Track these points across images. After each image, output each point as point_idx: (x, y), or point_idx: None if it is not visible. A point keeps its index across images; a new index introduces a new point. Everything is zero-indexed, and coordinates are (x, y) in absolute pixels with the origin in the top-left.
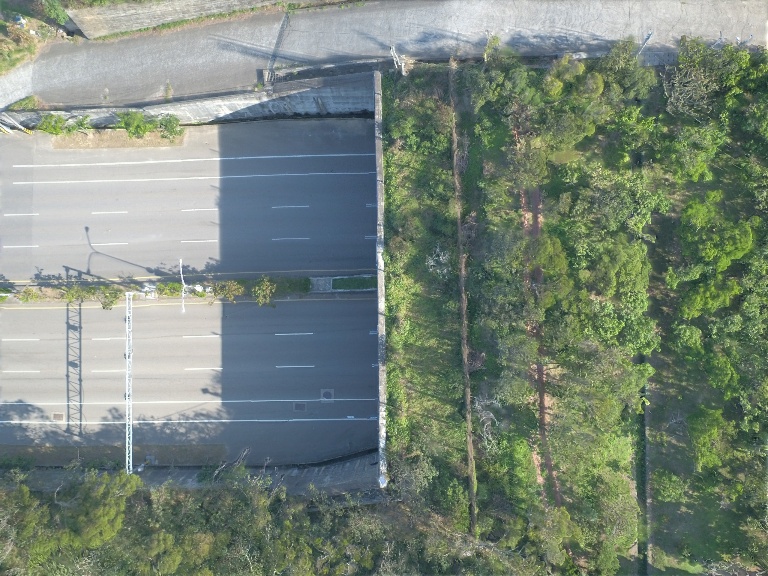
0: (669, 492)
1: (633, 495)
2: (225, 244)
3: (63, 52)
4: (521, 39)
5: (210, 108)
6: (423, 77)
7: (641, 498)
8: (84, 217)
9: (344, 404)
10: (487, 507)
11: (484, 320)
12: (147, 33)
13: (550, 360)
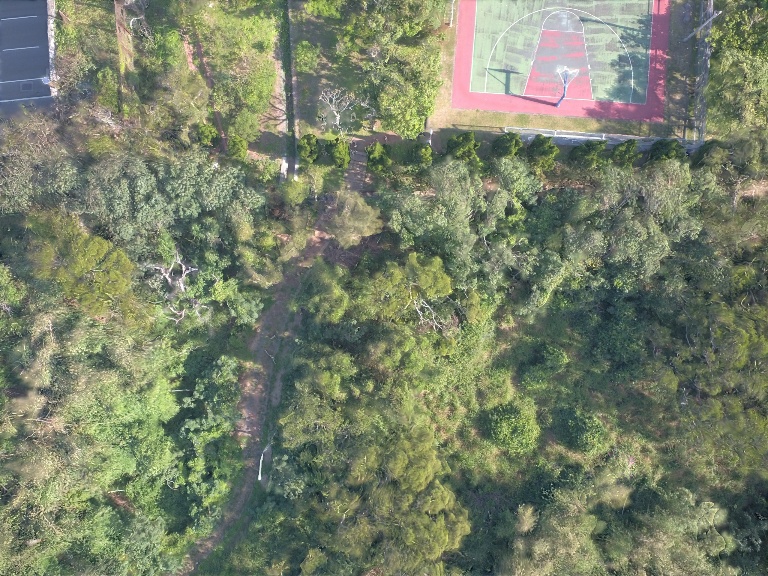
0: (301, 56)
1: (279, 74)
2: None
3: None
4: None
5: None
6: None
7: (289, 79)
8: None
9: None
10: (149, 103)
11: None
12: None
13: None
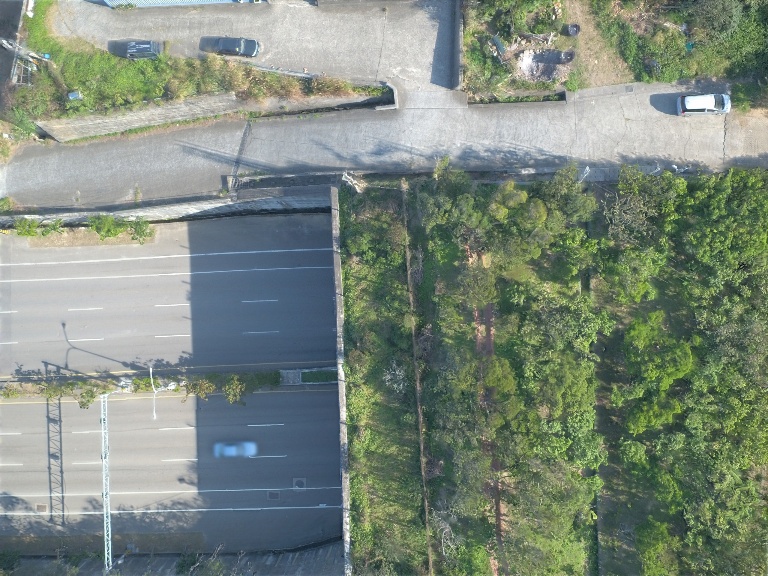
0: None
1: None
2: (197, 338)
3: (35, 154)
4: (472, 153)
5: (178, 210)
6: (378, 191)
7: None
8: (61, 314)
9: (316, 492)
10: None
11: (439, 435)
12: (115, 137)
13: (505, 469)
